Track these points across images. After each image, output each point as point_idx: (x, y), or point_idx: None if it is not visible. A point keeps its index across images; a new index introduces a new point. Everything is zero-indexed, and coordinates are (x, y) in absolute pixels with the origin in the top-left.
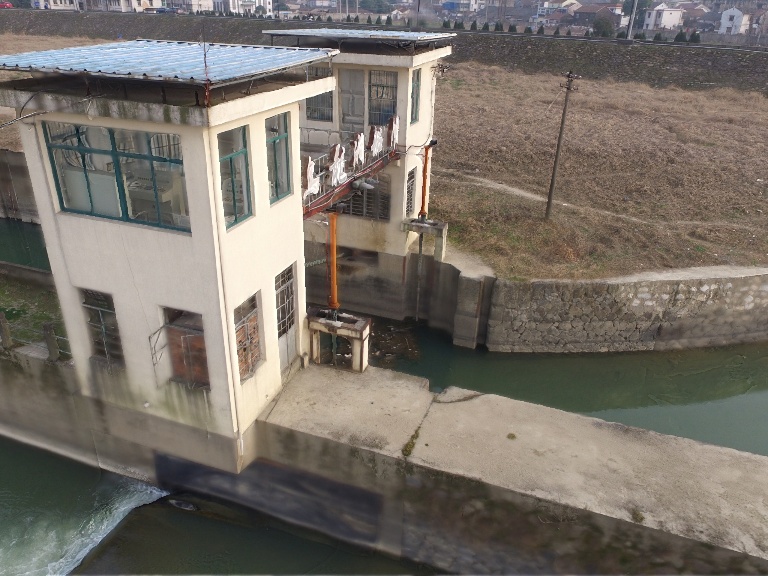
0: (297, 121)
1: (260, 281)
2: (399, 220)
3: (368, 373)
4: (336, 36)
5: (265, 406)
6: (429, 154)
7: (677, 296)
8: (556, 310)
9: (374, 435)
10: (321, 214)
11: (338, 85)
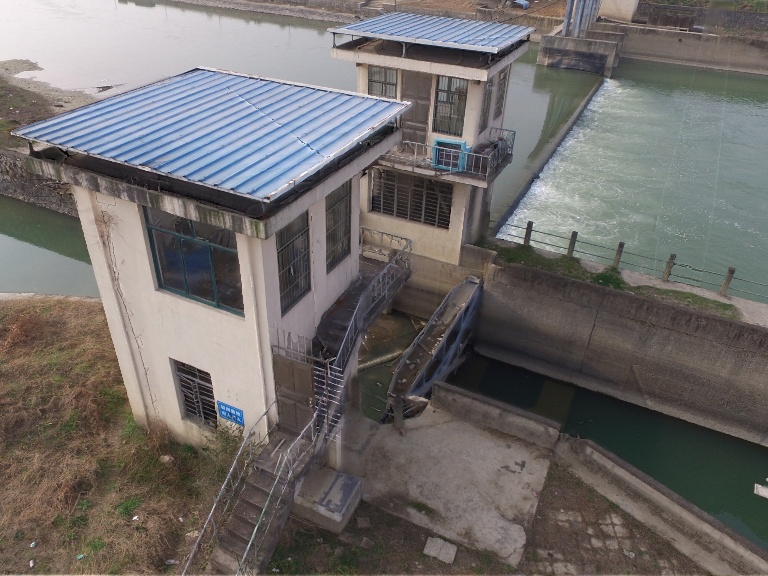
0: None
1: None
2: None
3: None
4: None
5: None
6: None
7: None
8: None
9: None
10: None
11: None
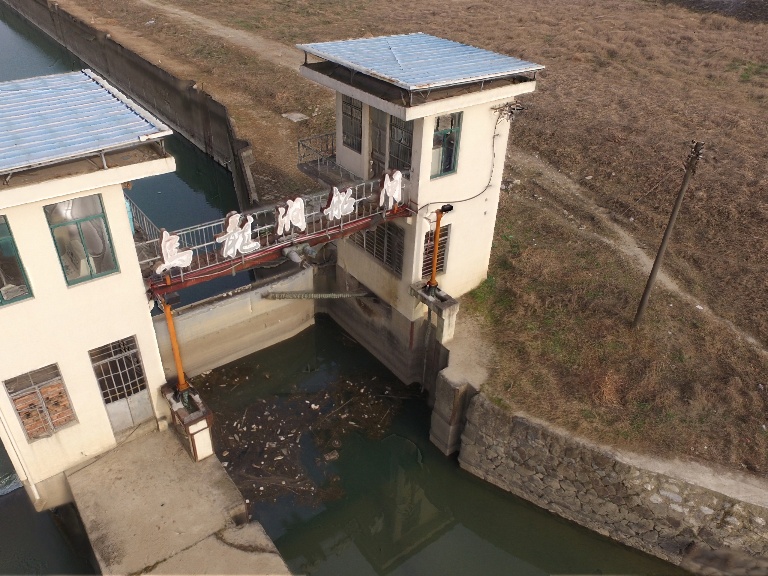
0: (120, 201)
1: (55, 355)
2: (409, 281)
3: (202, 465)
4: (346, 66)
5: (83, 460)
6: (489, 207)
7: (727, 517)
8: (540, 460)
9: (120, 545)
10: (159, 296)
11: (369, 115)
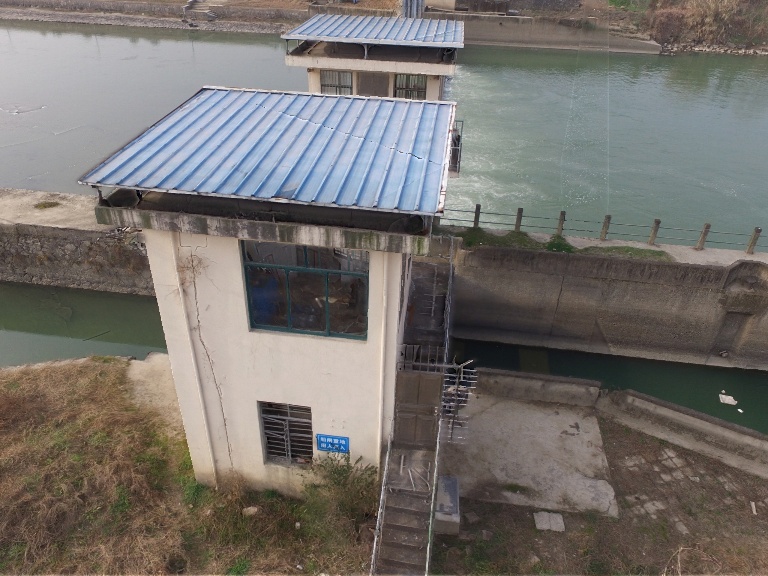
0: None
1: None
2: None
3: None
4: None
5: None
6: None
7: None
8: None
9: None
10: None
11: None
